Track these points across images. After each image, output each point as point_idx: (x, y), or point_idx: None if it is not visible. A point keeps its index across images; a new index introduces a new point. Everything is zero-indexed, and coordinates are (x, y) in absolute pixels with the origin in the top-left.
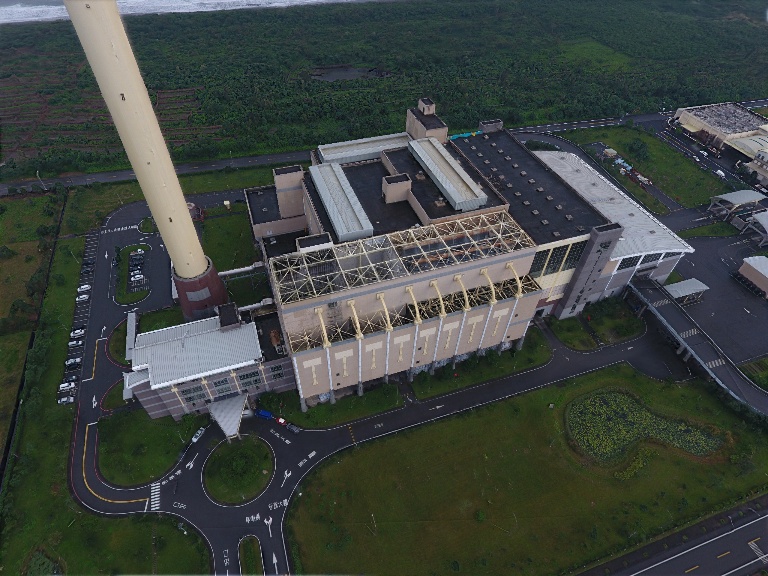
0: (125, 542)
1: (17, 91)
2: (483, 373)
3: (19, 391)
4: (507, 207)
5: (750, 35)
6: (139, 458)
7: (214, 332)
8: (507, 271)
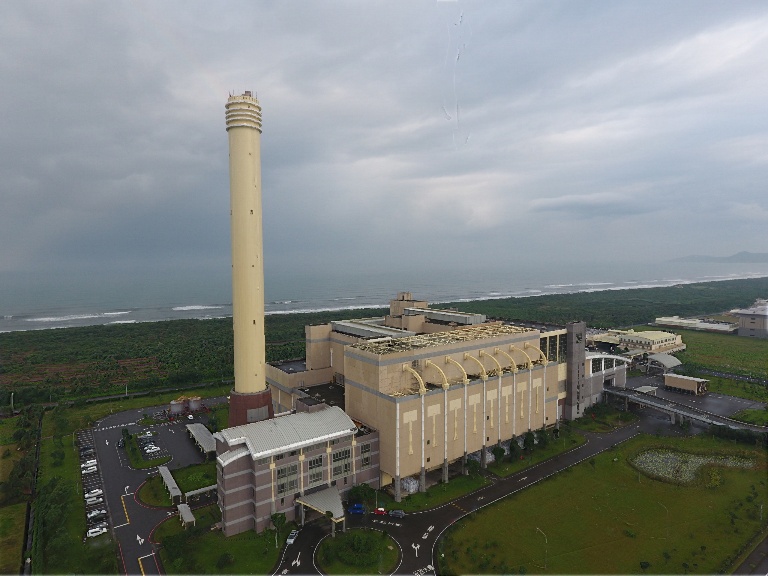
0: None
1: None
2: (542, 454)
3: (23, 550)
4: (501, 323)
5: (562, 311)
6: (227, 569)
7: (301, 414)
8: (526, 352)
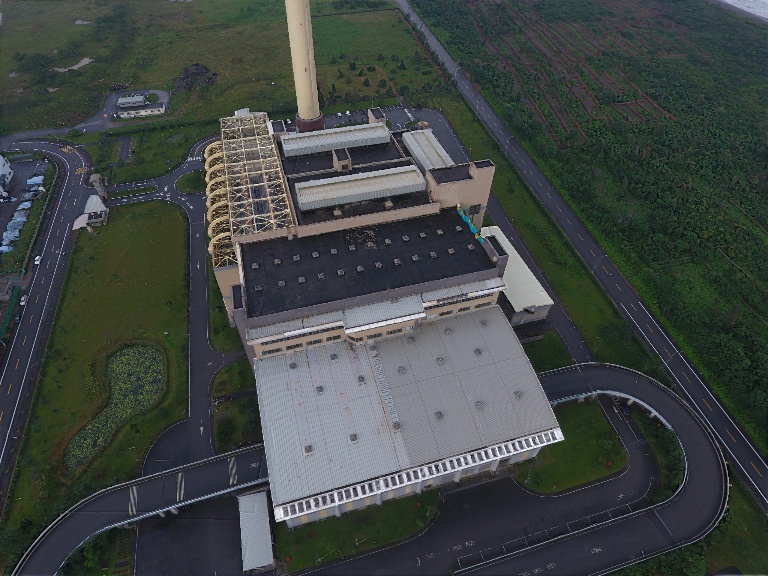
0: (176, 154)
1: (604, 45)
2: None
3: None
4: None
5: None
6: None
7: None
8: None
